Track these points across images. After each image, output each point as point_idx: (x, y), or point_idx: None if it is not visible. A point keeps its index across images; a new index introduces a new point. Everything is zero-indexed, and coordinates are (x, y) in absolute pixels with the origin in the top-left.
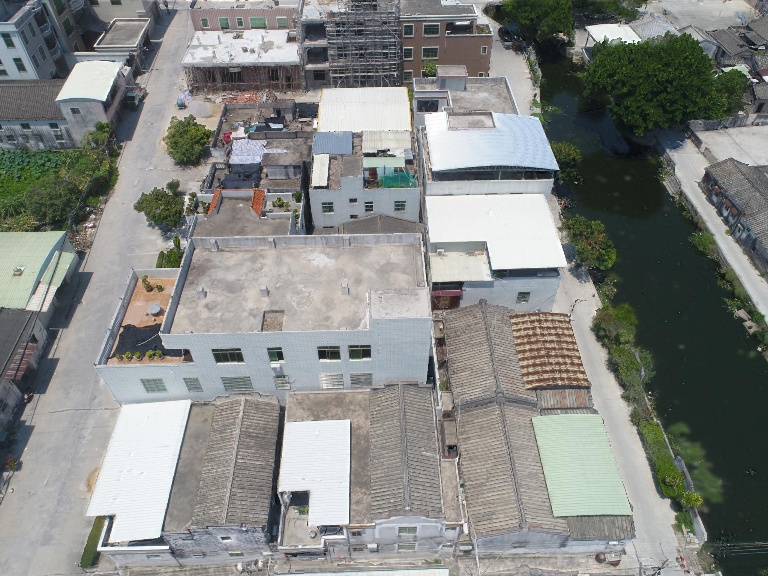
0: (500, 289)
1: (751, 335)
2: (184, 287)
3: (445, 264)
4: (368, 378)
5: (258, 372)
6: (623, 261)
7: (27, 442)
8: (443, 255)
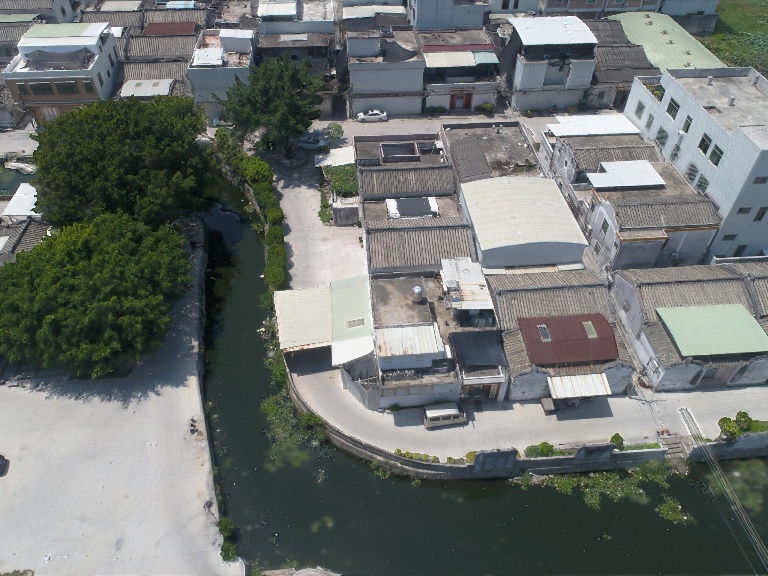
0: None
1: None
2: None
3: None
4: None
5: (674, 135)
6: None
7: None
8: None
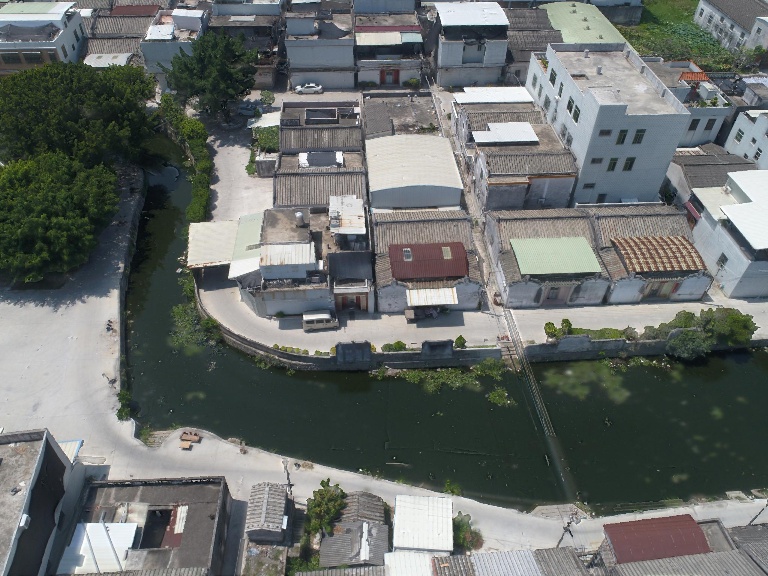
0: None
1: None
2: (589, 52)
3: (717, 195)
4: None
5: None
6: None
7: None
8: (727, 193)
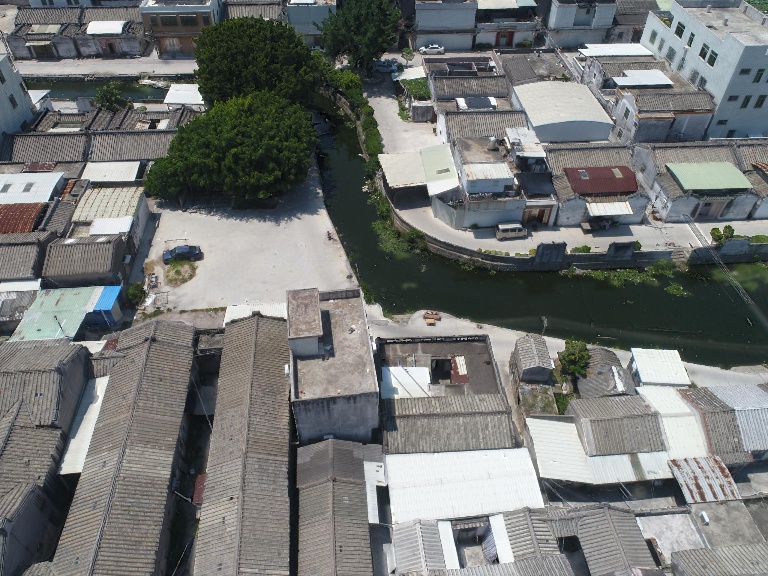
0: None
1: None
2: None
3: None
4: (704, 85)
5: (680, 50)
6: None
7: None
8: None
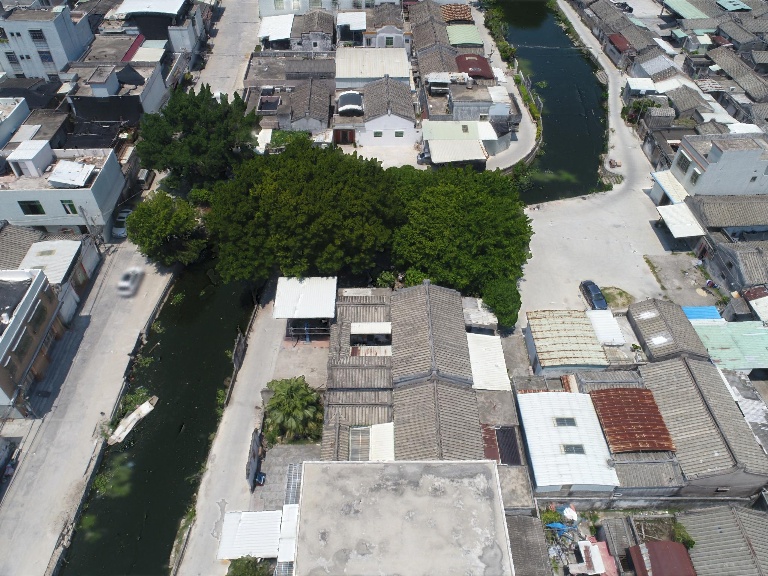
0: (437, 1)
1: (564, 31)
2: None
3: None
4: (373, 3)
5: None
6: (507, 11)
7: (213, 48)
8: None
